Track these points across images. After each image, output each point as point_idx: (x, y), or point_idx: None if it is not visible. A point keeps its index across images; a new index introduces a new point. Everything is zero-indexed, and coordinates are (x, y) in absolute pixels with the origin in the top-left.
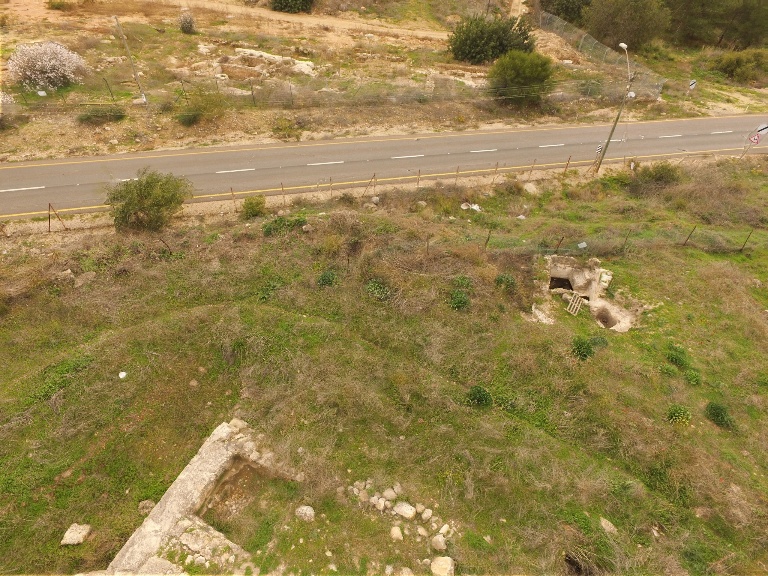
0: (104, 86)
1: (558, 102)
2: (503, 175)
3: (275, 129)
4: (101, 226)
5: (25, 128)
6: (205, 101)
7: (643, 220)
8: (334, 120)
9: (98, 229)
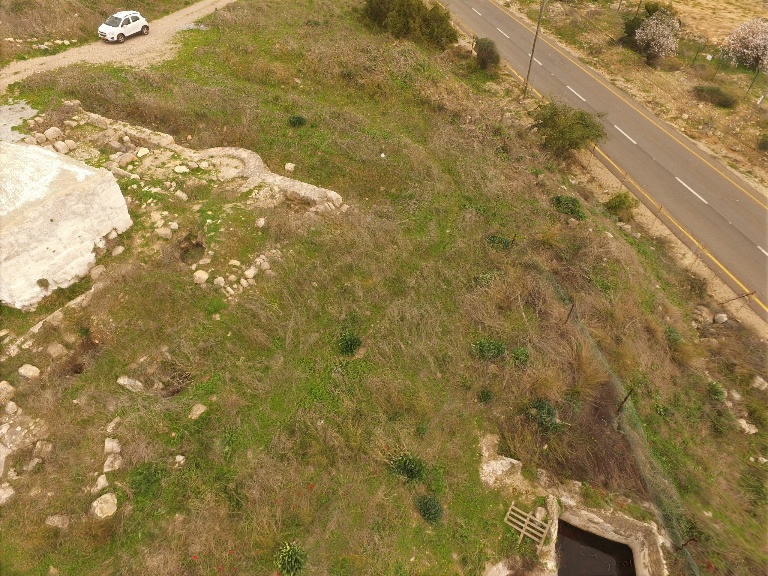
0: None
1: None
2: None
3: None
4: None
5: (660, 73)
6: None
7: None
8: None
9: None
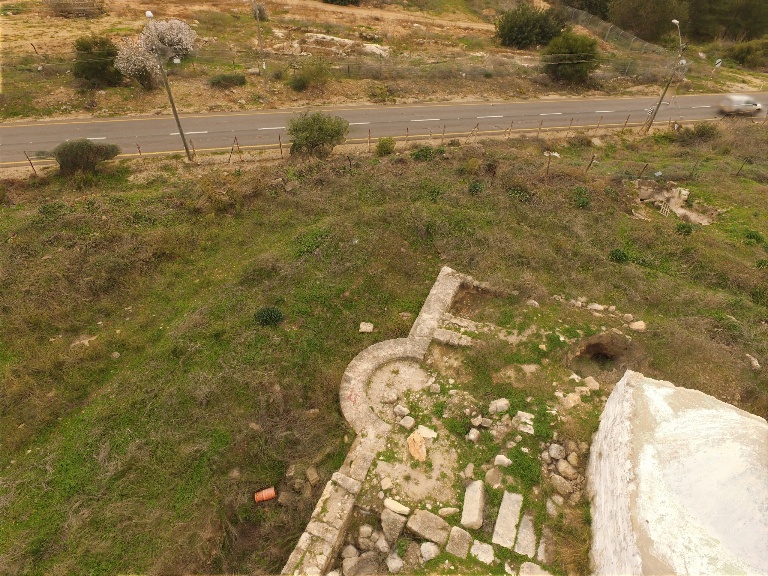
0: (215, 59)
1: (600, 80)
2: (573, 131)
3: (371, 95)
4: (267, 159)
5: None
6: (315, 69)
7: (699, 160)
8: (418, 89)
9: (265, 162)
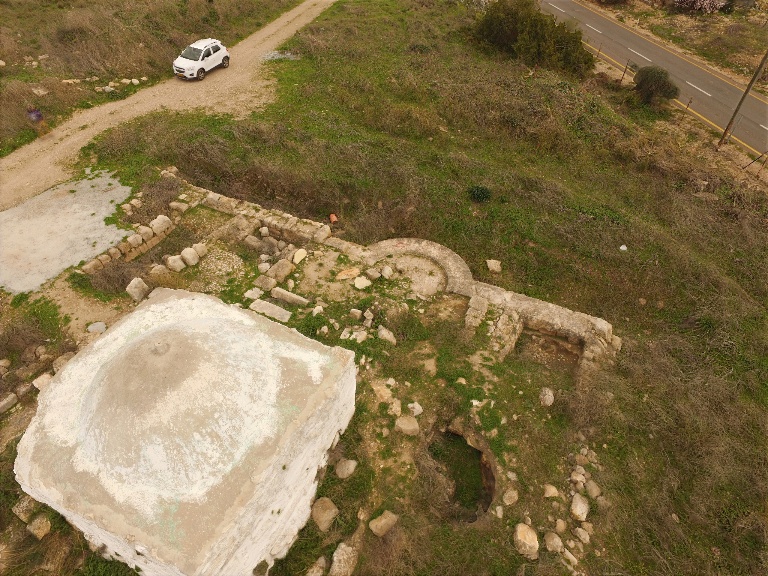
0: None
1: None
2: None
3: None
4: None
5: None
6: None
7: None
8: None
9: None
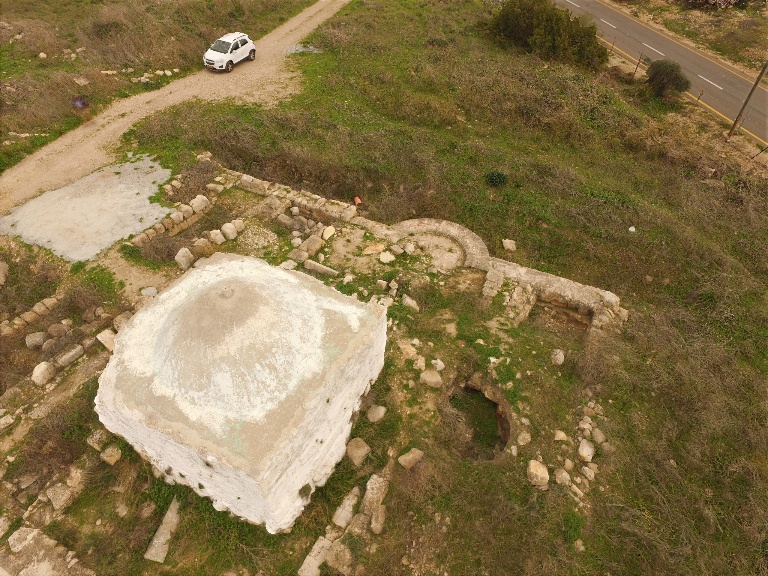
0: None
1: None
2: None
3: None
4: None
5: None
6: None
7: None
8: None
9: None
